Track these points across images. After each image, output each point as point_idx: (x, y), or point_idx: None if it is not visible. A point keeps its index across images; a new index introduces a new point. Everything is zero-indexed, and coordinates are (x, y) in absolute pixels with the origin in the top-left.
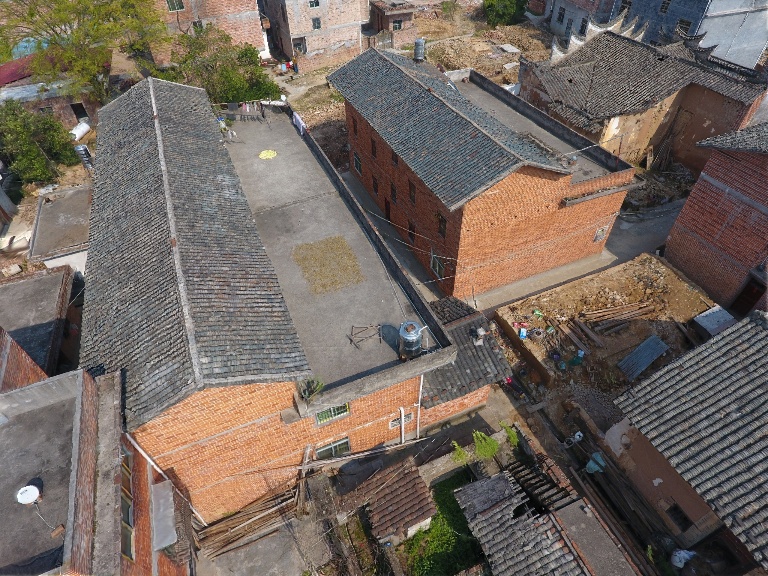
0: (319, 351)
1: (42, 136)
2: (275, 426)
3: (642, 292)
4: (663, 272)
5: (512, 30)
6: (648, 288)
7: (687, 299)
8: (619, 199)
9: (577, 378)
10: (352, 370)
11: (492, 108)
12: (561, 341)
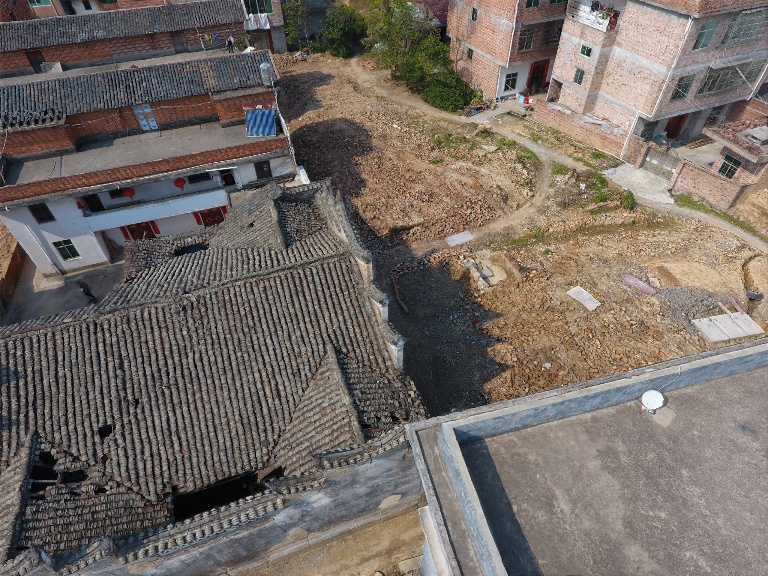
0: None
1: None
2: None
3: None
4: None
5: None
6: None
7: None
8: None
9: None
10: None
11: None
12: None
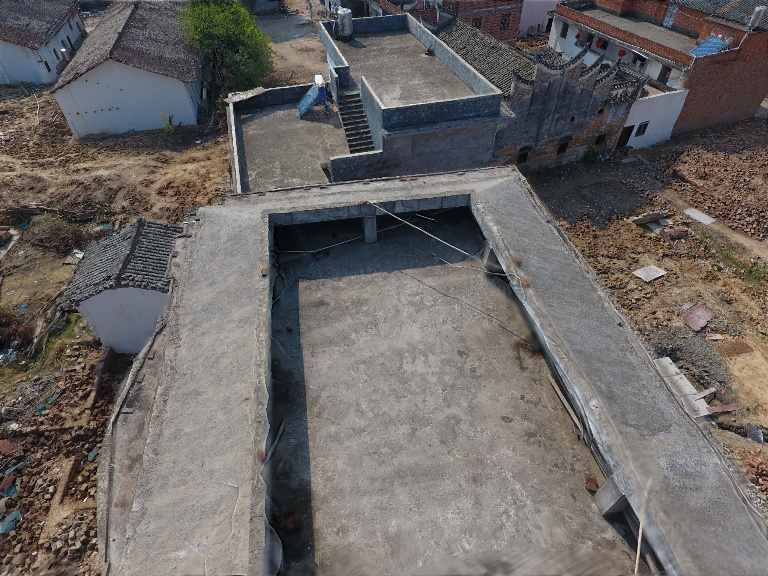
0: None
1: None
2: None
3: None
4: None
5: None
6: None
7: None
8: None
9: None
10: None
11: None
12: None
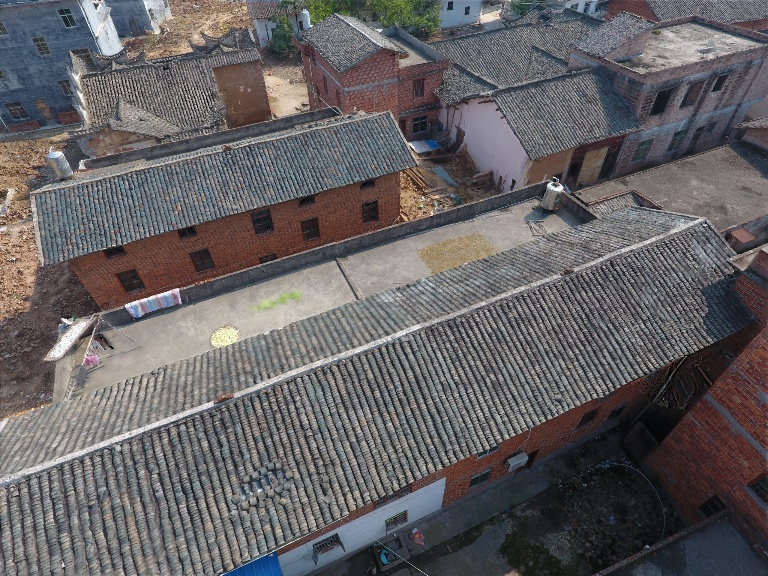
0: None
1: None
2: None
3: None
4: None
5: None
6: None
7: None
8: None
9: None
10: None
11: None
12: None
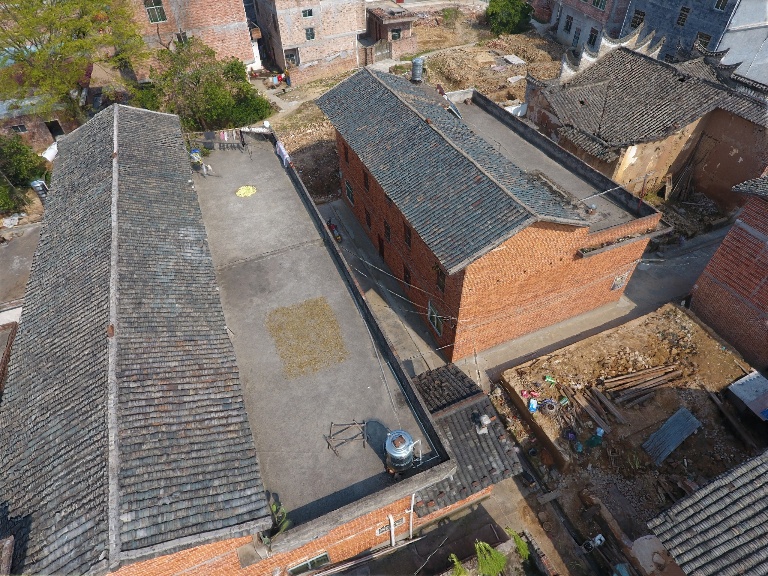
0: (289, 458)
1: (8, 161)
2: (232, 561)
3: (667, 352)
4: (690, 328)
5: (517, 39)
6: (674, 347)
7: (719, 363)
8: (641, 246)
9: (596, 462)
10: (328, 487)
11: (497, 135)
12: (577, 416)
